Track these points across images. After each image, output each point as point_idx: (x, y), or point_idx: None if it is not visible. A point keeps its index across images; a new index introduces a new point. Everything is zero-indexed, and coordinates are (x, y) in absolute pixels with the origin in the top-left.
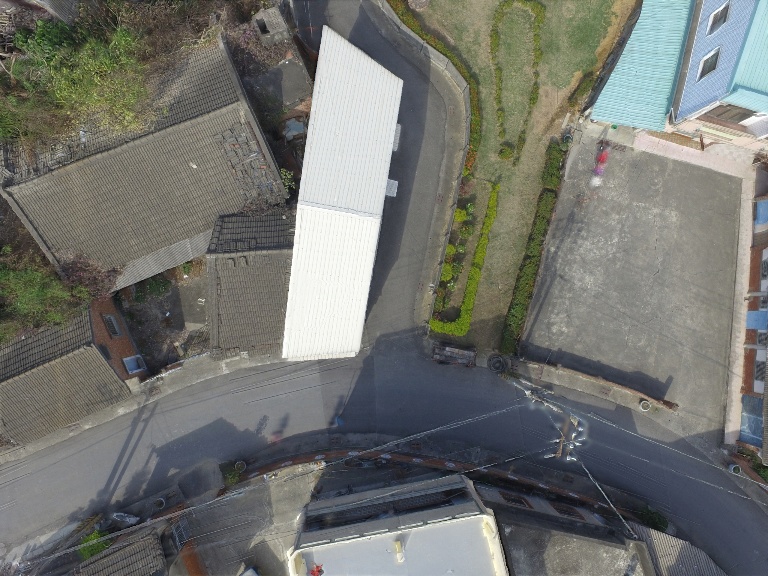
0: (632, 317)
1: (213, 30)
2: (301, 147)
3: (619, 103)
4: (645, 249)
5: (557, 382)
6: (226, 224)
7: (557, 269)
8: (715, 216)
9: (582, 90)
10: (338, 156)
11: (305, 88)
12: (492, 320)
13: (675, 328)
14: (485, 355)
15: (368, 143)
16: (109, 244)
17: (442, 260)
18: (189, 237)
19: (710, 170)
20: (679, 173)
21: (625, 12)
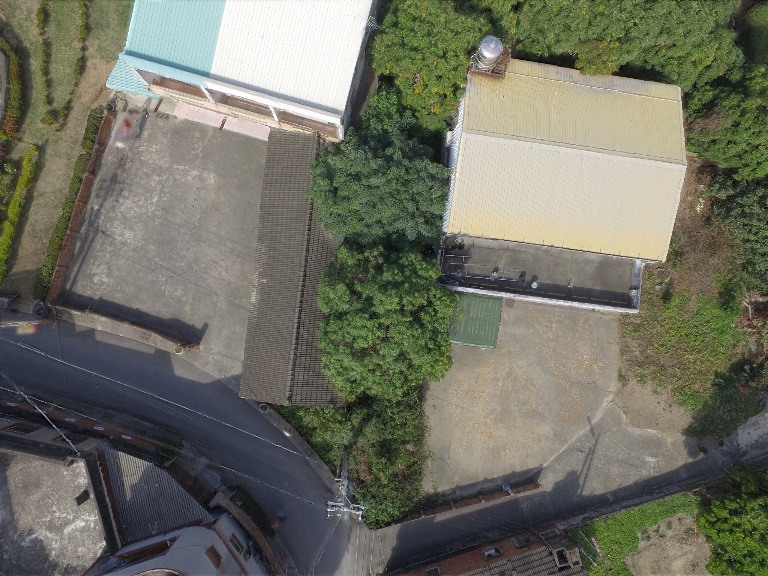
0: (169, 269)
1: None
2: None
3: (128, 73)
4: (183, 207)
5: (100, 328)
6: None
7: (99, 225)
8: (253, 178)
9: None
10: None
11: None
12: (36, 271)
13: (210, 279)
14: (31, 303)
15: None
16: None
17: None
18: None
19: (249, 136)
20: (219, 139)
21: None
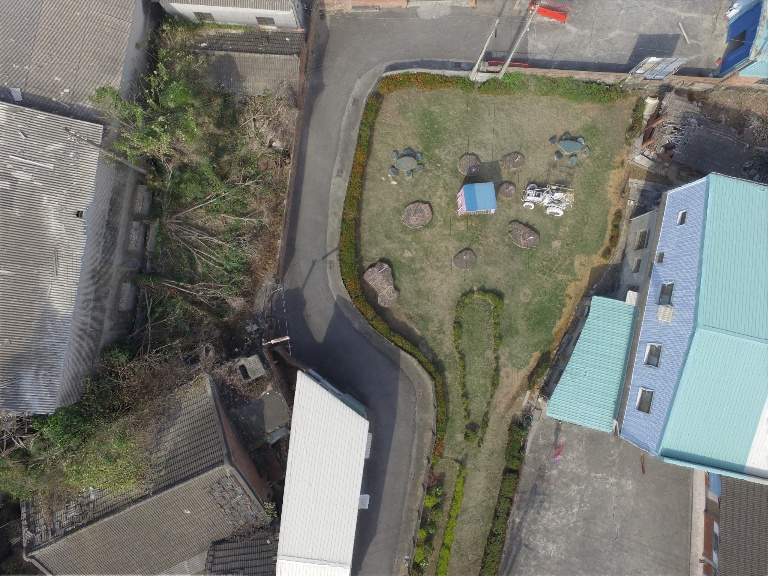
0: None
1: (202, 376)
2: (285, 442)
3: (571, 402)
4: (604, 517)
5: None
6: (217, 553)
7: (522, 539)
8: (669, 482)
9: (539, 375)
10: (312, 506)
11: (284, 416)
12: None
13: None
14: None
15: (338, 490)
16: (117, 575)
17: (414, 542)
18: (186, 559)
19: None
20: None
21: (579, 293)
